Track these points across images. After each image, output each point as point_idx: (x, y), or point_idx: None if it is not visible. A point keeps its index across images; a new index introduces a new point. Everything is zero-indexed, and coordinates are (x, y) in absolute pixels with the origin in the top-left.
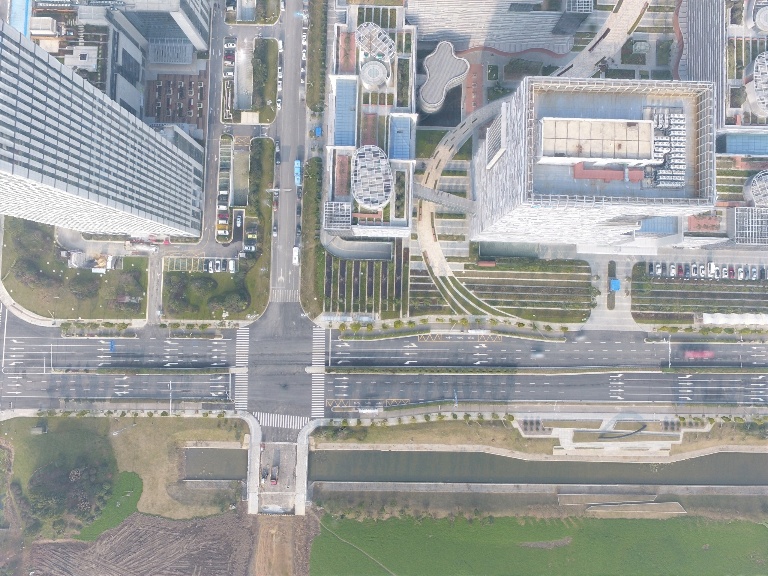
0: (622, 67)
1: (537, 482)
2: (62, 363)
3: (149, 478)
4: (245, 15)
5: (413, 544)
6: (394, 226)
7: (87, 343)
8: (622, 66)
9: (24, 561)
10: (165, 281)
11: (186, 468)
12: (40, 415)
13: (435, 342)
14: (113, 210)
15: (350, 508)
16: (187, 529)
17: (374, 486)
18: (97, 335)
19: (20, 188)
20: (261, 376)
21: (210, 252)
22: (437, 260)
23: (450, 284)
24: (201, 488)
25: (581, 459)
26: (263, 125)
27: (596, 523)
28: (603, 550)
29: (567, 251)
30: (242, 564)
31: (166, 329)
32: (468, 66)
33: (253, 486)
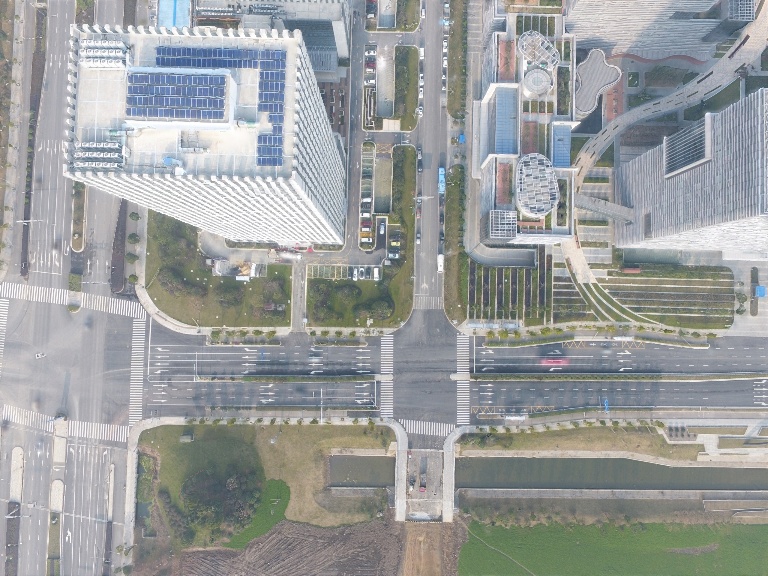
0: (762, 74)
1: (681, 488)
2: (207, 371)
3: (296, 486)
4: (383, 22)
5: (561, 551)
6: (557, 234)
7: (232, 351)
8: (762, 73)
9: (173, 569)
10: (313, 289)
11: (330, 475)
12: (190, 423)
13: (579, 349)
14: (318, 221)
15: (500, 515)
16: (335, 536)
17: (519, 493)
18: (242, 343)
19: (276, 202)
20: (406, 383)
21: (353, 259)
22: (580, 267)
23: (593, 291)
24: (347, 495)
25: (725, 465)
26: (404, 132)
27: (742, 529)
28: (750, 556)
29: (710, 257)
30: (391, 571)
31: (310, 337)
32: (620, 74)
33: (400, 493)
